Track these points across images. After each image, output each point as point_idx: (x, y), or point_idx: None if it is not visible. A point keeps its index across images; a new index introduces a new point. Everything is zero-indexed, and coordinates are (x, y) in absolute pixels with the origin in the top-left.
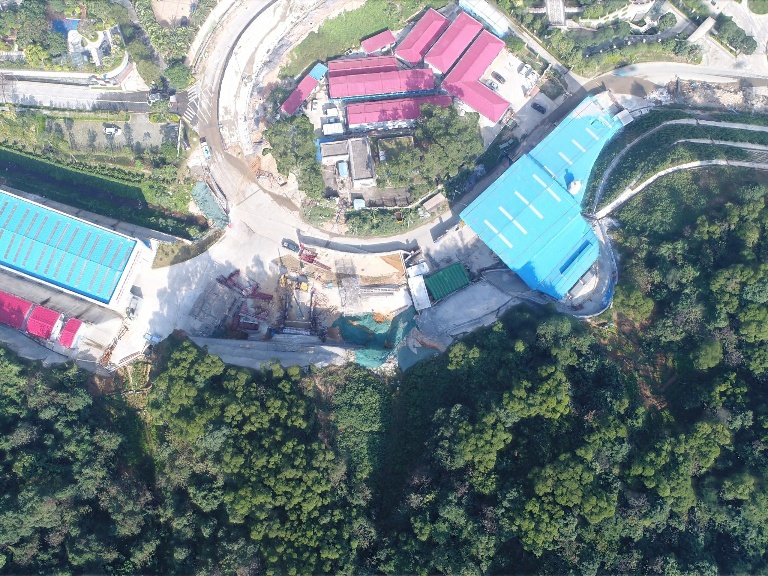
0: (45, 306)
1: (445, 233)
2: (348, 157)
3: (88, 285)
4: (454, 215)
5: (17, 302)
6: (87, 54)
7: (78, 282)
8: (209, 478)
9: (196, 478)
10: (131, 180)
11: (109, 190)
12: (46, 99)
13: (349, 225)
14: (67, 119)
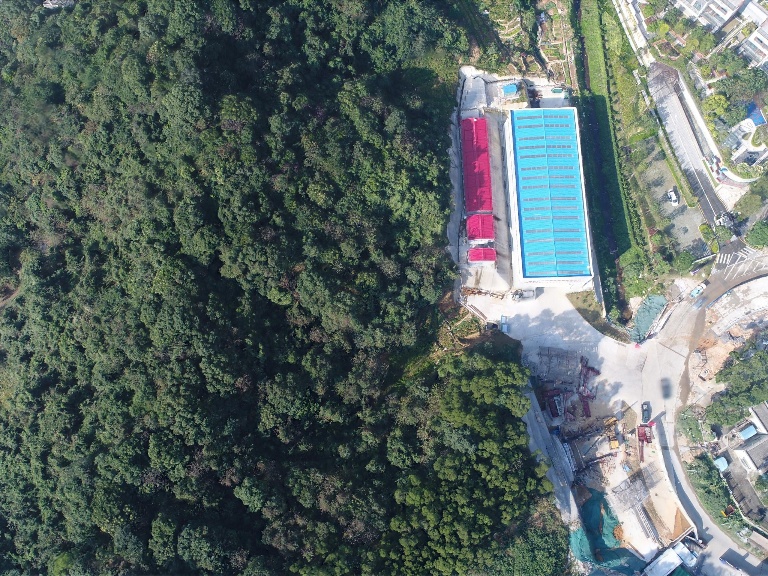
0: (494, 220)
1: (737, 568)
2: (764, 432)
3: (532, 251)
4: (758, 568)
5: (488, 197)
6: (737, 144)
7: (530, 241)
8: (417, 446)
9: (409, 431)
10: (636, 235)
11: (615, 218)
12: (673, 127)
13: (696, 462)
14: (663, 153)
